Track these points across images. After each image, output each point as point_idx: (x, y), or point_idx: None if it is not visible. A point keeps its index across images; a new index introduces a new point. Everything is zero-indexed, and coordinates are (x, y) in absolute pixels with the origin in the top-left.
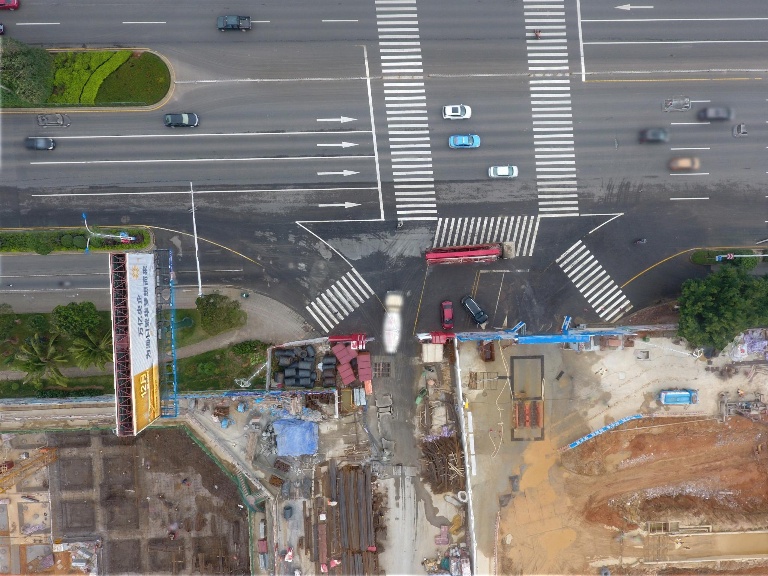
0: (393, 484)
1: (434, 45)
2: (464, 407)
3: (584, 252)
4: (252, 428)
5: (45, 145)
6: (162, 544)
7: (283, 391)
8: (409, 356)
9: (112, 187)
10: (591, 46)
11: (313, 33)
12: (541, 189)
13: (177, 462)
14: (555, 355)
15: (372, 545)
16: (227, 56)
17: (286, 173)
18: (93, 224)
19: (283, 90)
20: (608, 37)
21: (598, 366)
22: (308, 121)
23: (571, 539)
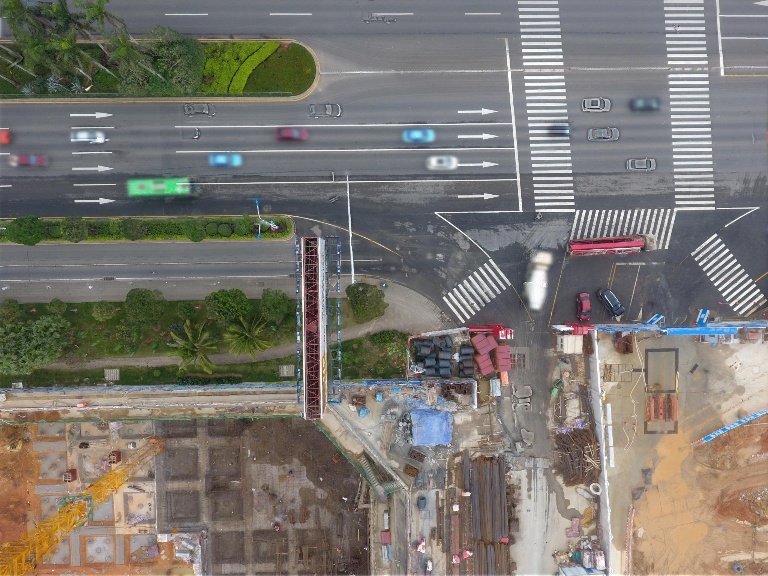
0: (525, 476)
1: (575, 39)
2: (602, 399)
3: (719, 245)
4: (388, 418)
5: (190, 134)
6: (266, 536)
7: (420, 381)
8: (544, 347)
9: (255, 176)
10: (729, 41)
11: (456, 26)
12: (678, 182)
13: (283, 454)
14: (690, 348)
15: (505, 536)
16: (371, 48)
17: (426, 164)
18: (237, 213)
19: (426, 82)
20: (746, 32)
21: (732, 360)
22: (449, 113)
23: (702, 533)
